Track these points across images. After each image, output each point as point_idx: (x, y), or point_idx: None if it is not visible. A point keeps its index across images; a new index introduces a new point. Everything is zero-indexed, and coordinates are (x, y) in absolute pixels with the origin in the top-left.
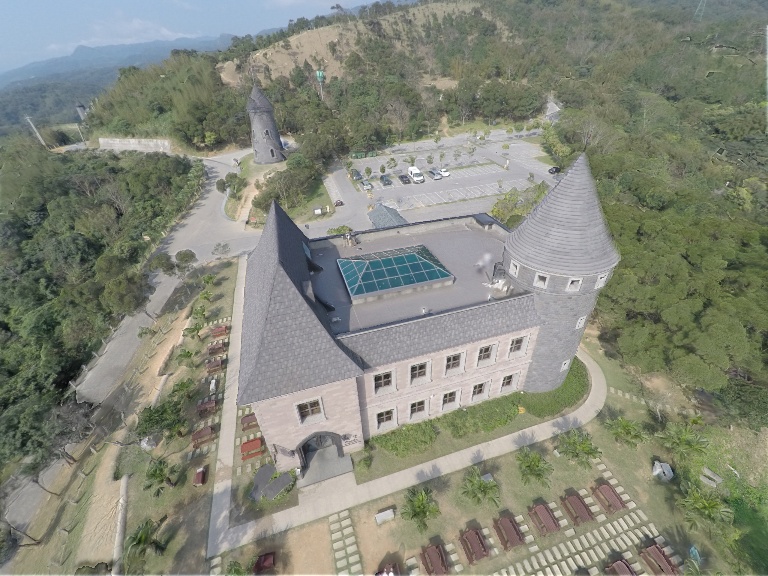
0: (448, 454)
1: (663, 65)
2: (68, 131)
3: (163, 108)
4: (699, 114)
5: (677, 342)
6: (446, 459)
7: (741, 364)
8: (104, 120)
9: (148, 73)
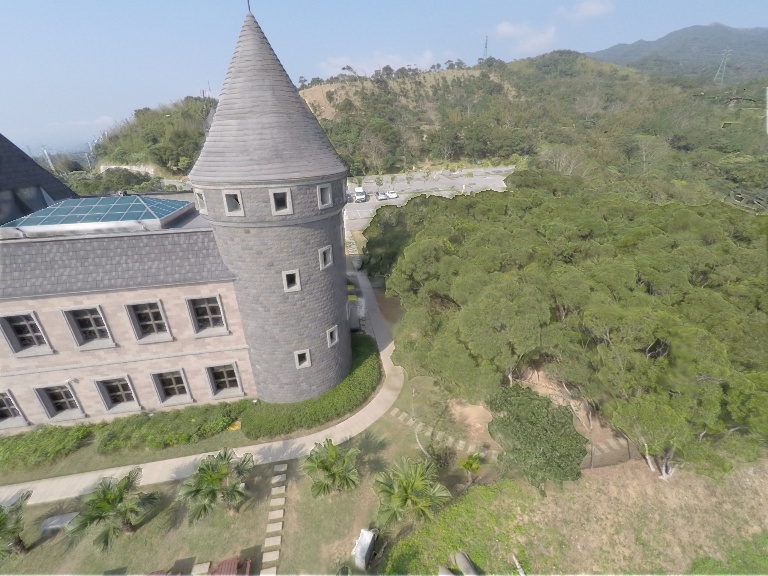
0: (63, 475)
1: (673, 117)
2: (83, 162)
3: (157, 140)
4: (714, 162)
5: (453, 327)
6: (51, 482)
7: (578, 378)
8: (108, 150)
9: (156, 113)
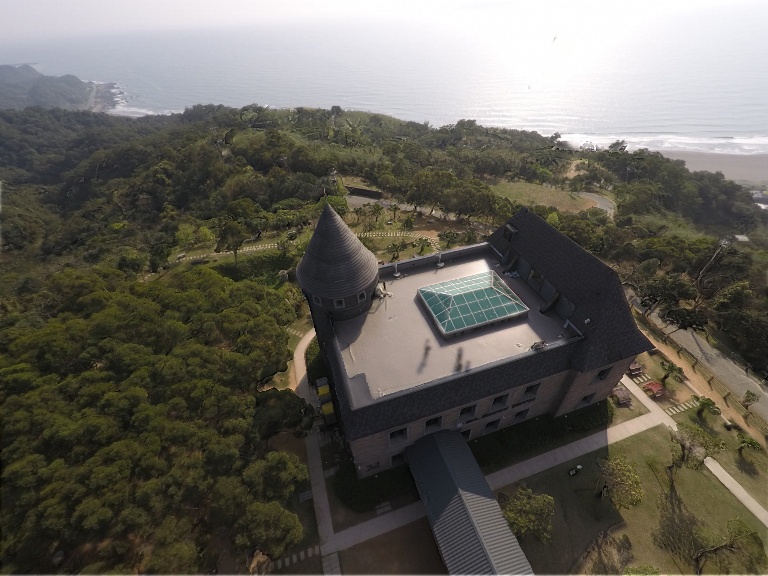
0: None
1: None
2: None
3: None
4: None
5: None
6: None
7: None
8: None
9: None
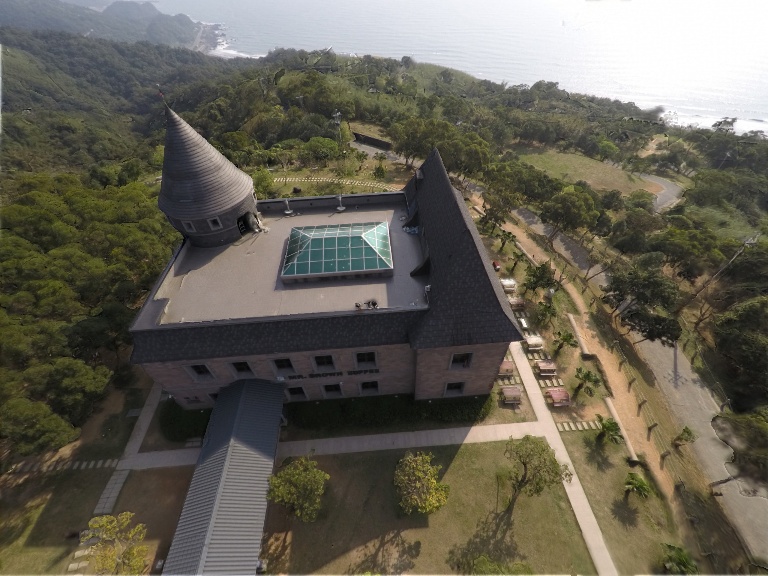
0: None
1: None
2: None
3: None
4: None
5: None
6: None
7: None
8: None
9: None
